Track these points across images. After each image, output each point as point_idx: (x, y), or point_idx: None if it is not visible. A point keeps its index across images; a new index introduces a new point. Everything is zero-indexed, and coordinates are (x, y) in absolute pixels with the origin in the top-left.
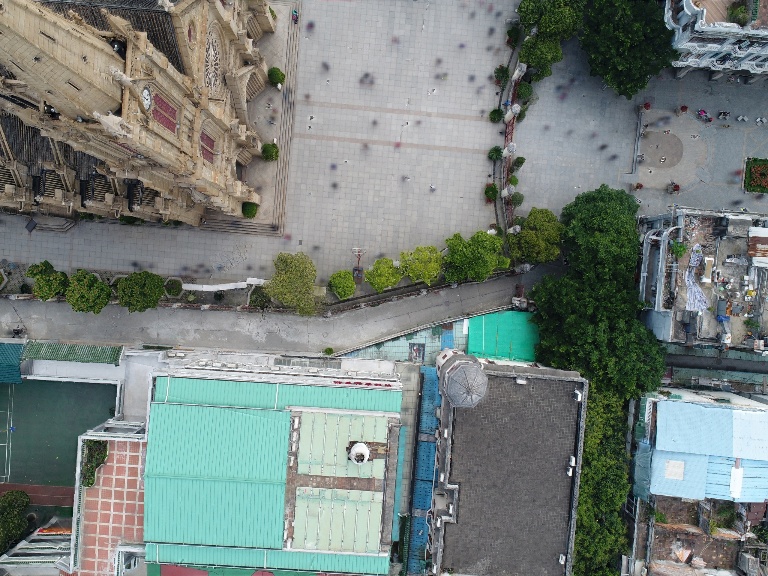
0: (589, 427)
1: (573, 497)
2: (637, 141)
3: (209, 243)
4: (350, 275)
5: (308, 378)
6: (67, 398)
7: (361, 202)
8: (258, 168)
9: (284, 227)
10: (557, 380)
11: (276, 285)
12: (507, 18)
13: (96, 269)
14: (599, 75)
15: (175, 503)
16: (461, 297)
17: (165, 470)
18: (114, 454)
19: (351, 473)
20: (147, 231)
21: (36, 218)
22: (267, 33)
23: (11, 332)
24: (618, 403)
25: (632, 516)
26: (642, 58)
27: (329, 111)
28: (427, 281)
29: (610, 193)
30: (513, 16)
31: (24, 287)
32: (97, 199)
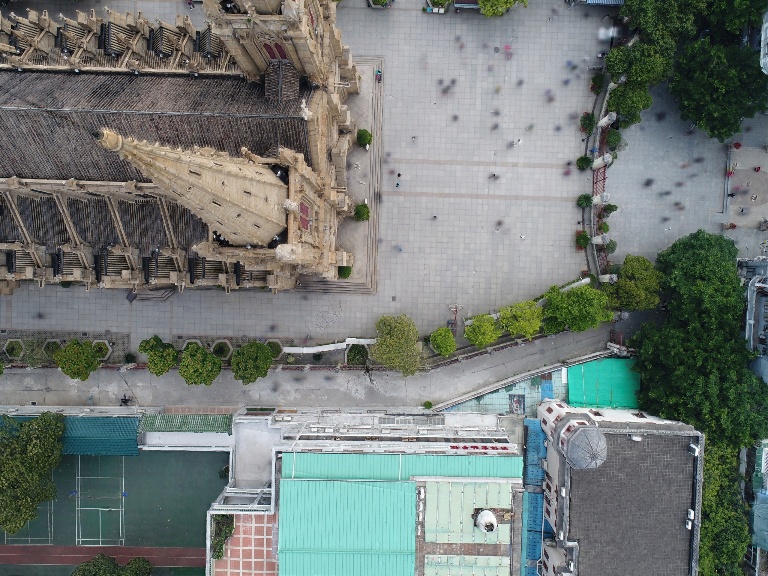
0: (706, 480)
1: (692, 549)
2: (727, 180)
3: (304, 304)
4: (449, 332)
5: (424, 444)
6: (175, 462)
7: (452, 256)
8: (349, 228)
9: (377, 284)
10: (672, 435)
11: (383, 350)
12: (590, 64)
13: (196, 335)
14: (691, 120)
15: (308, 575)
16: (556, 345)
17: (298, 545)
18: (240, 526)
19: (478, 539)
20: (243, 295)
21: None
22: (352, 94)
23: (118, 400)
24: (732, 453)
25: (751, 564)
26: (737, 103)
27: (416, 167)
28: (528, 336)
29: (709, 239)
30: (596, 62)
31: (129, 357)
32: (208, 277)
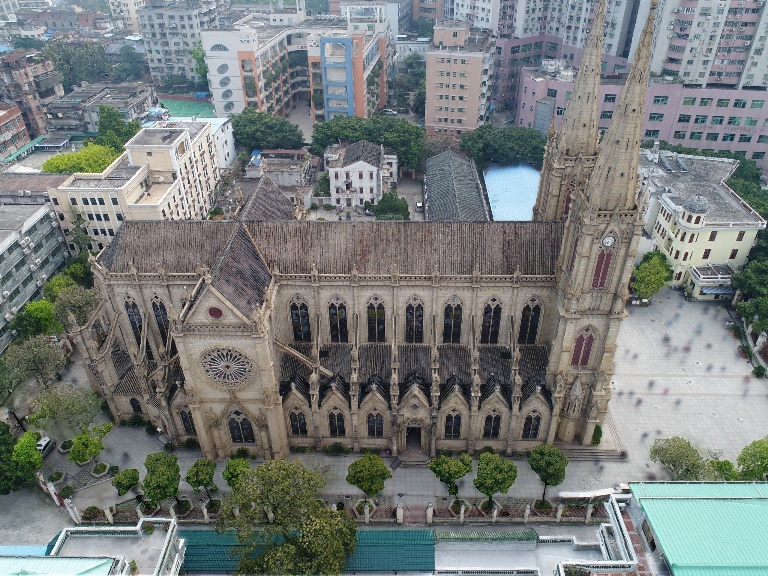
0: None
1: None
2: None
3: None
4: None
5: None
6: None
7: (685, 433)
8: None
9: (626, 454)
10: None
11: None
12: None
13: (461, 497)
14: None
15: None
16: None
17: (692, 560)
18: None
19: None
20: None
21: (401, 457)
22: None
23: None
24: None
25: None
26: None
27: (624, 378)
28: None
29: None
30: None
31: None
32: None
